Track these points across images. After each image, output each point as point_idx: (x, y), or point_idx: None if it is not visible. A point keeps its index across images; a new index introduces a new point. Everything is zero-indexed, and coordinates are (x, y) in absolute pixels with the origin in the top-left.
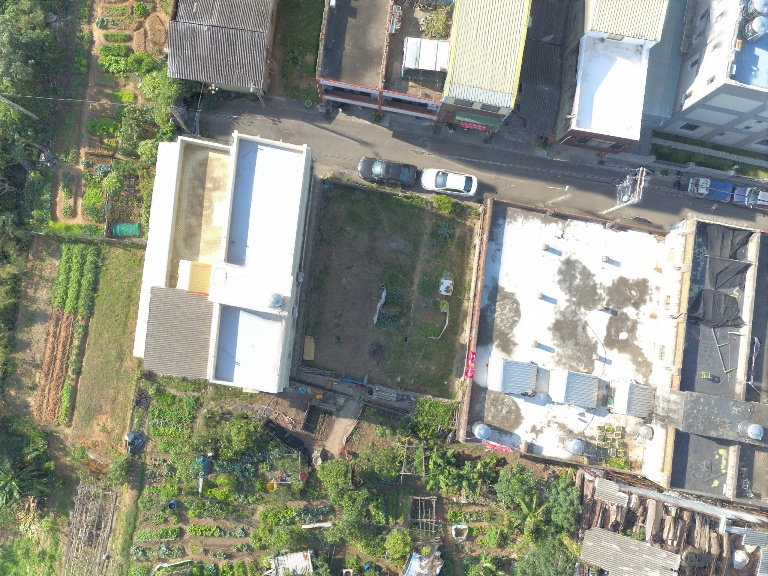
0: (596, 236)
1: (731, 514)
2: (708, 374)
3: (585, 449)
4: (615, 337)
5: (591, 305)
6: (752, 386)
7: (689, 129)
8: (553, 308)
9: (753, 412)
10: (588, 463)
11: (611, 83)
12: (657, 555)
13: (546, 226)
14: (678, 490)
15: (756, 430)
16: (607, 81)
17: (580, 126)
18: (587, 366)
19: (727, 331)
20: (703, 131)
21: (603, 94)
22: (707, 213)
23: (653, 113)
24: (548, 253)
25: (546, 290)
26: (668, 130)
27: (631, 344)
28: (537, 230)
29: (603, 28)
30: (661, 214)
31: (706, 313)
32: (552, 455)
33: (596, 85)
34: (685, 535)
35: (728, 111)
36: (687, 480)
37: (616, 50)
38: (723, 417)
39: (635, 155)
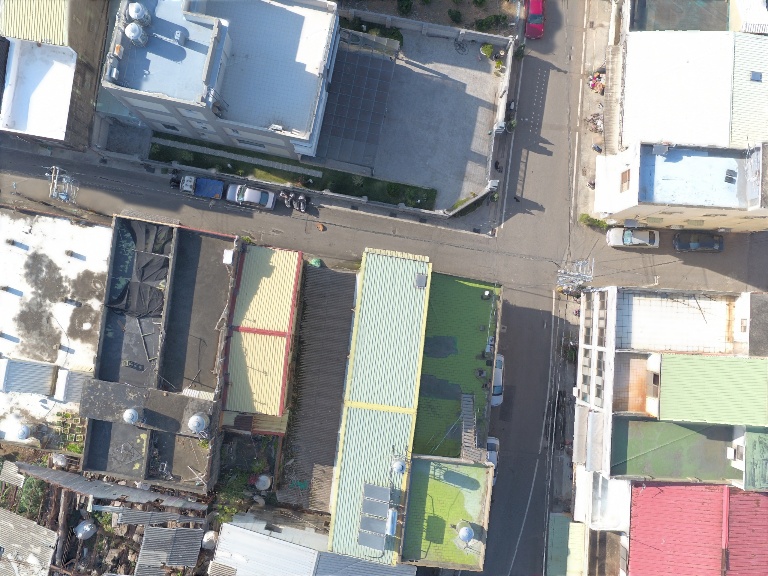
0: (63, 231)
1: (123, 494)
2: (126, 362)
3: (45, 434)
4: (79, 328)
5: (56, 297)
6: (158, 374)
7: (174, 129)
8: (19, 300)
9: (148, 398)
10: (41, 447)
11: (46, 85)
12: (40, 533)
13: (15, 222)
14: (93, 472)
15: (128, 415)
16: (43, 84)
17: (16, 126)
18: (50, 355)
19: (152, 322)
20: (185, 131)
21: (39, 96)
22: (205, 209)
23: (122, 114)
24: (16, 247)
25: (13, 283)
26: (163, 130)
27: (94, 334)
28: (5, 226)
29: (11, 33)
30: (160, 210)
31: (131, 304)
32: (13, 440)
33: (32, 87)
34: (62, 514)
35: (158, 112)
36: (109, 463)
37: (53, 54)
38: (119, 403)
39: (119, 154)
